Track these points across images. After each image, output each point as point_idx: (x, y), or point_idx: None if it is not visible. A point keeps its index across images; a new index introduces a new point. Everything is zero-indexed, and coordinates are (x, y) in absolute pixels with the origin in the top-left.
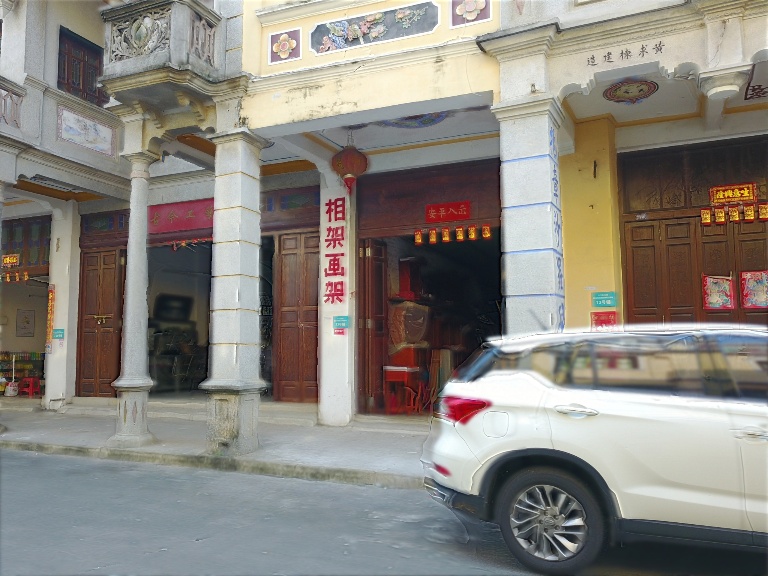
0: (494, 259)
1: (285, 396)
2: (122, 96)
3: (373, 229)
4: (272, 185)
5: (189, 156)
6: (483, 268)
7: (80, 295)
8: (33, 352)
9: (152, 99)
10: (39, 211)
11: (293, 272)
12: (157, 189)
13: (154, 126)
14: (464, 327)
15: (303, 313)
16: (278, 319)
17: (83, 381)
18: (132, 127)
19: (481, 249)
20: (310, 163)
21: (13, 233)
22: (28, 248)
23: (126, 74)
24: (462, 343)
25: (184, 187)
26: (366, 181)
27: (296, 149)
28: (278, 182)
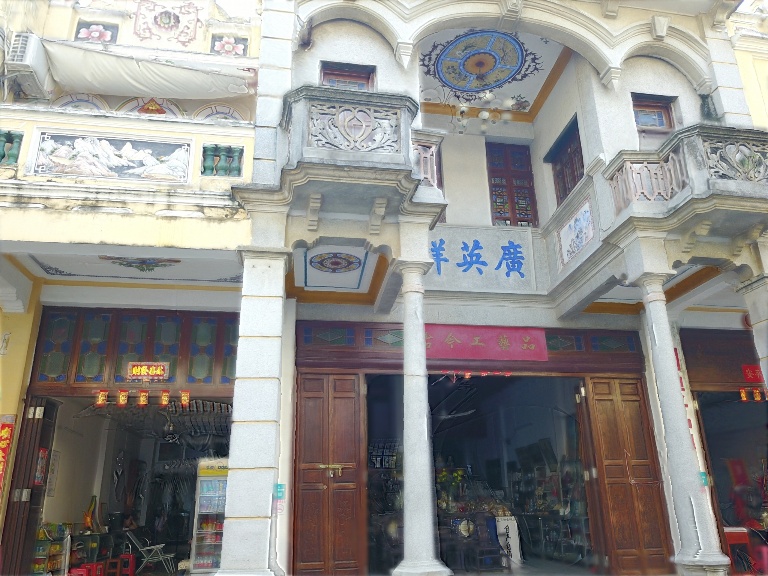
0: (767, 420)
1: (626, 569)
2: (709, 214)
3: (698, 382)
4: (584, 323)
5: (617, 283)
6: (760, 428)
7: (297, 433)
8: (53, 523)
9: (718, 224)
10: (226, 305)
11: (613, 420)
12: (430, 305)
13: (676, 249)
14: (738, 485)
15: (632, 467)
16: (605, 474)
17: (302, 567)
18: (651, 244)
19: (764, 410)
20: (629, 308)
21: (155, 330)
22: (189, 356)
23: (751, 196)
24: (733, 501)
25: (468, 308)
26: (683, 334)
27: (703, 296)
28: (592, 321)
